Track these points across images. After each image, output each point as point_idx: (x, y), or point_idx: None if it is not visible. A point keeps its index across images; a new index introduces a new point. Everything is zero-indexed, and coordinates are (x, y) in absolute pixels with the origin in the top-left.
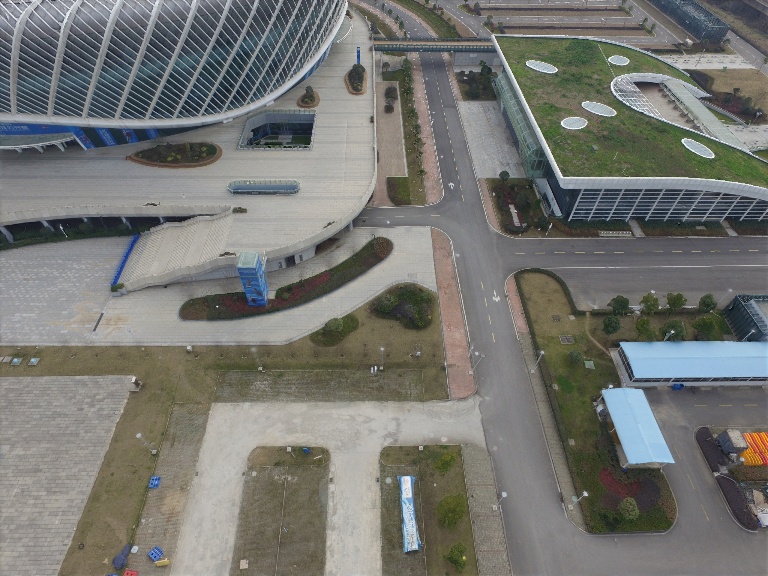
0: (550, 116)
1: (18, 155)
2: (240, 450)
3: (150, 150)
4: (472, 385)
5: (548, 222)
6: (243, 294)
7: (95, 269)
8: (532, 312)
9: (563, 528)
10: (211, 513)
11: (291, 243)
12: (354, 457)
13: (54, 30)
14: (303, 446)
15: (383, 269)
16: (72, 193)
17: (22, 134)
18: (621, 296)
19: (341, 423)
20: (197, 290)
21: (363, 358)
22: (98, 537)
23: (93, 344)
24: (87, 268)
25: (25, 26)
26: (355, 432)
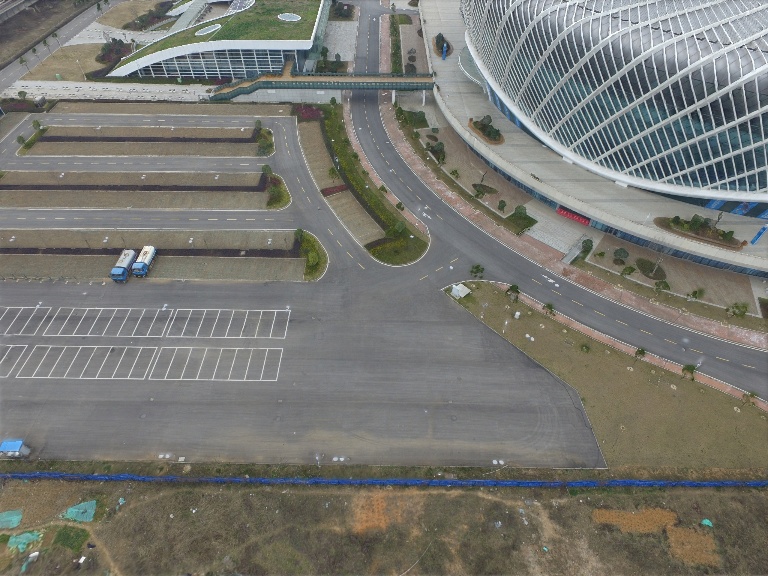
0: None
1: None
2: None
3: None
4: None
5: (330, 7)
6: None
7: None
8: None
9: None
10: None
11: None
12: None
13: None
14: None
15: None
16: None
17: None
18: None
19: None
20: None
21: None
22: None
23: None
24: None
25: None
26: None
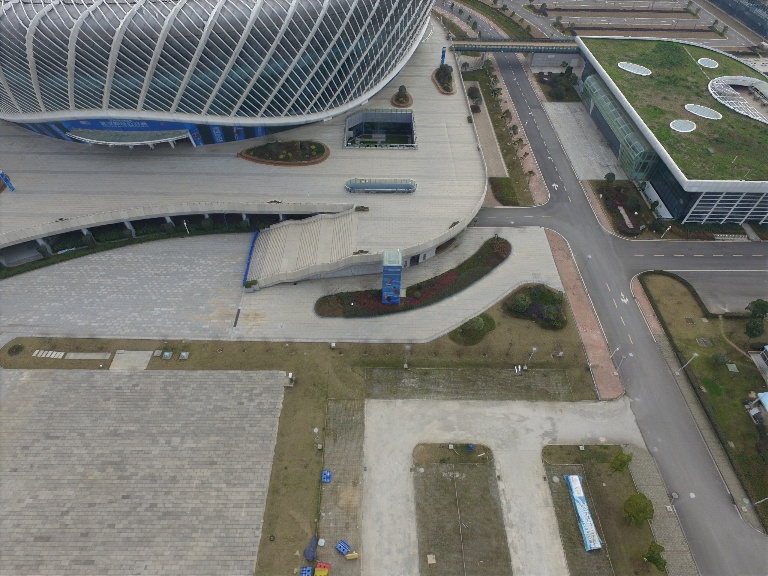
0: (657, 118)
1: (130, 151)
2: (403, 446)
3: (261, 148)
4: (620, 386)
5: None
6: (376, 292)
7: (222, 265)
8: (664, 314)
9: (741, 530)
10: (388, 508)
11: (422, 242)
12: (517, 455)
13: (198, 28)
14: (464, 444)
15: (506, 269)
16: (193, 189)
17: (139, 130)
18: (762, 300)
19: (496, 421)
20: (327, 287)
21: (506, 357)
22: (286, 529)
23: (237, 339)
24: (214, 264)
25: (172, 24)
26: (512, 431)
